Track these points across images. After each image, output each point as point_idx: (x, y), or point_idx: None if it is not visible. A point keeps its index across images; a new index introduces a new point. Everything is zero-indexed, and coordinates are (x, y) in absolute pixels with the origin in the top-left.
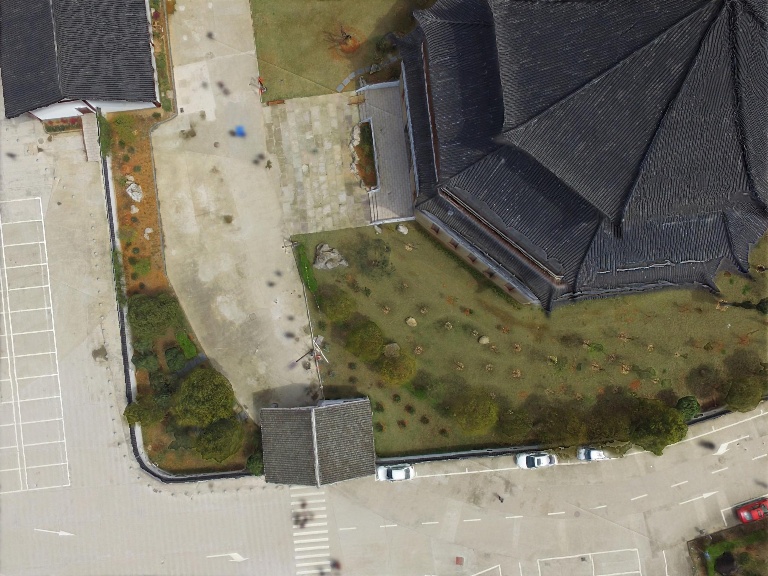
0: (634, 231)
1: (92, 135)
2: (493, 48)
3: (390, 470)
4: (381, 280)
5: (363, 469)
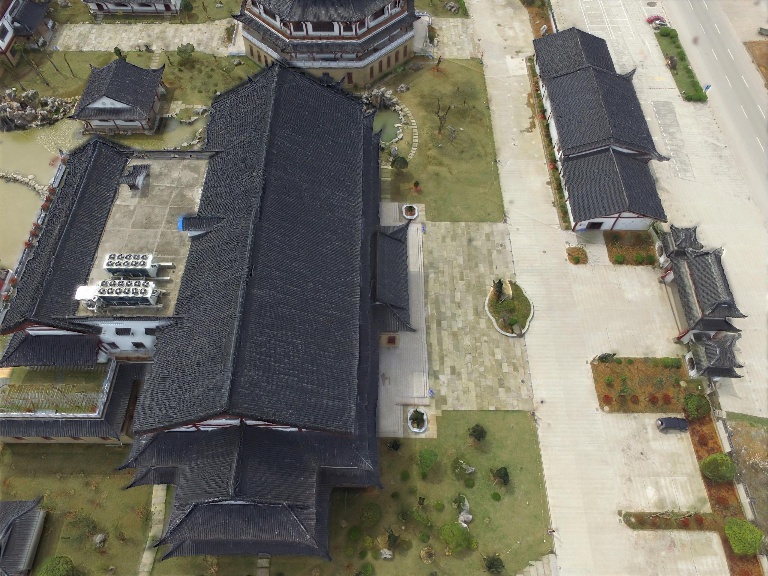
0: None
1: None
2: None
3: None
4: (429, 1)
5: None
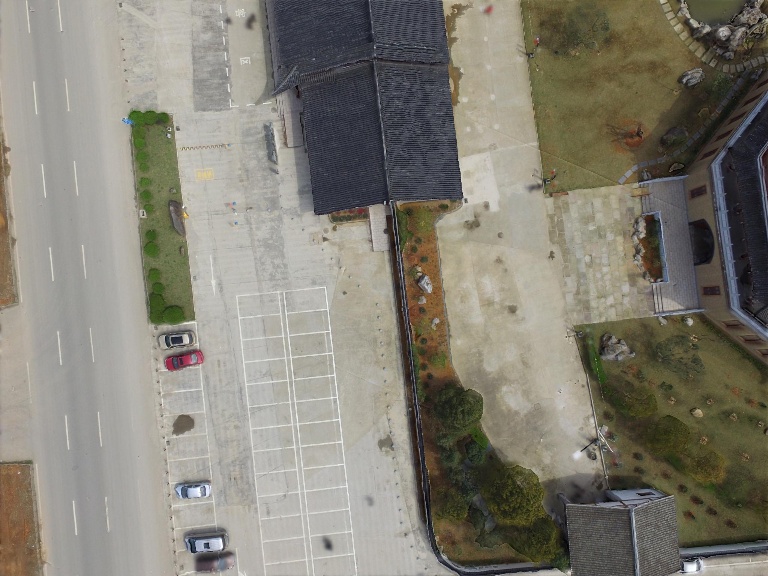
0: None
1: (379, 225)
2: None
3: (680, 562)
4: (666, 371)
5: (671, 566)
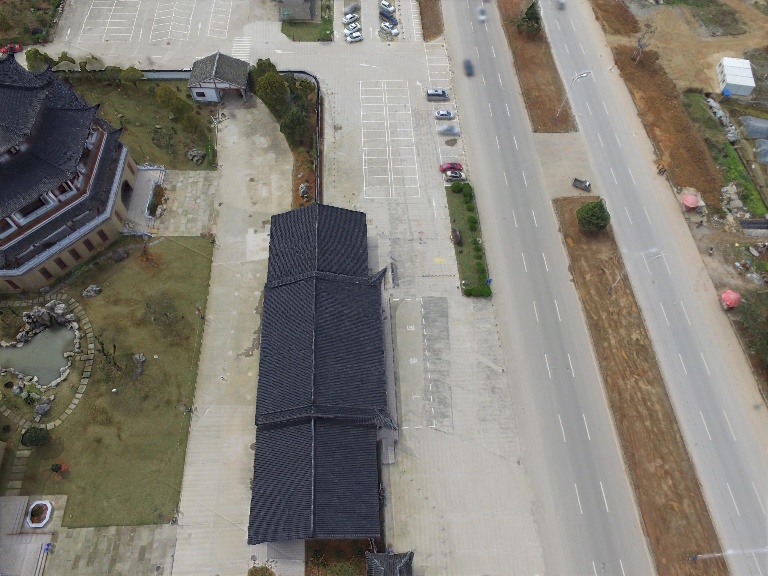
0: None
1: None
2: (40, 146)
3: None
4: None
5: None
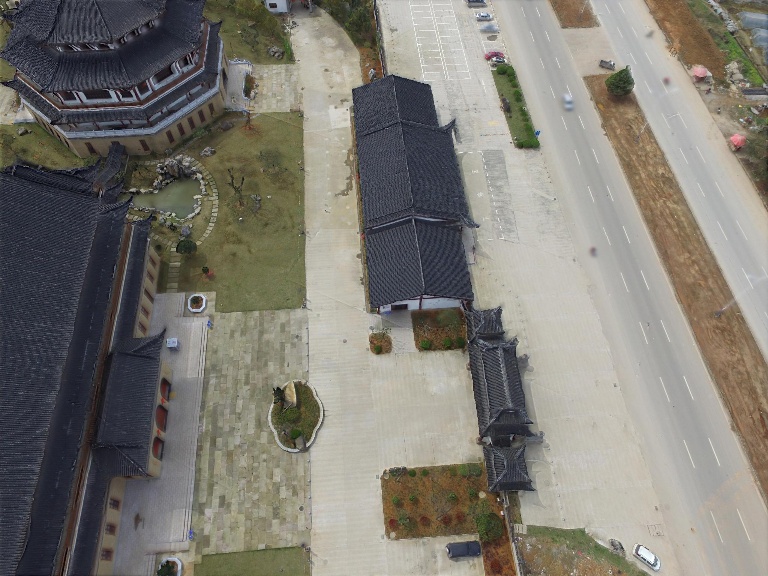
0: None
1: None
2: (168, 24)
3: None
4: None
5: None
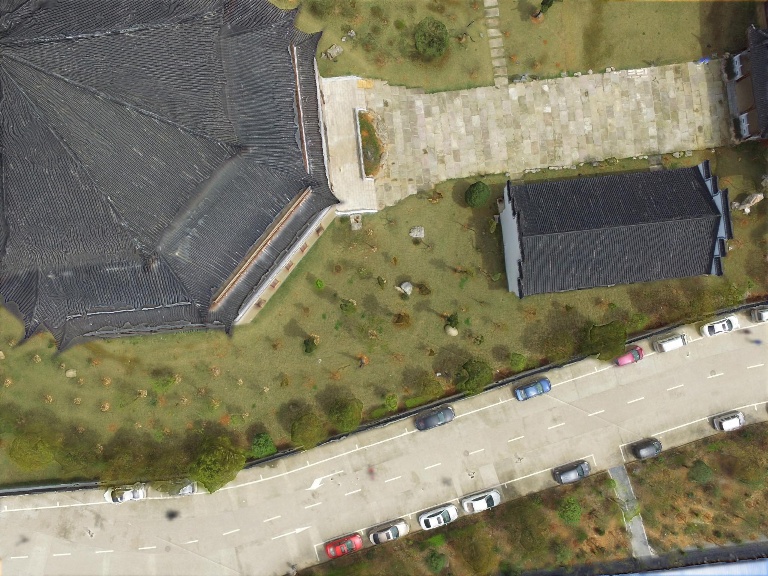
0: (78, 276)
1: None
2: None
3: None
4: None
5: None
